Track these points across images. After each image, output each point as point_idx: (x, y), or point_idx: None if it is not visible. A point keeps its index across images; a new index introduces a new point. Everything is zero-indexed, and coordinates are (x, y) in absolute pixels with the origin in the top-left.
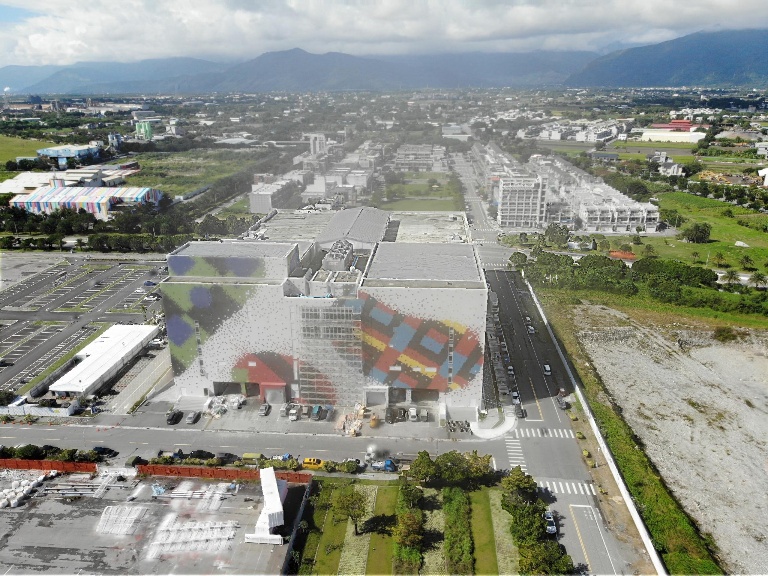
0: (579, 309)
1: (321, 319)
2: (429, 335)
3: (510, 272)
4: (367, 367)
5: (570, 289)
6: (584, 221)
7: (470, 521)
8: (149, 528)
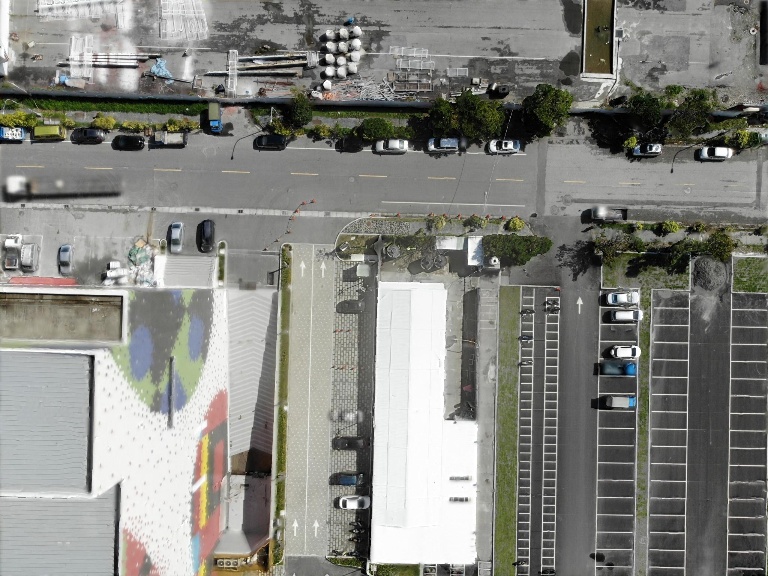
0: None
1: None
2: None
3: None
4: None
5: None
6: None
7: None
8: (144, 6)
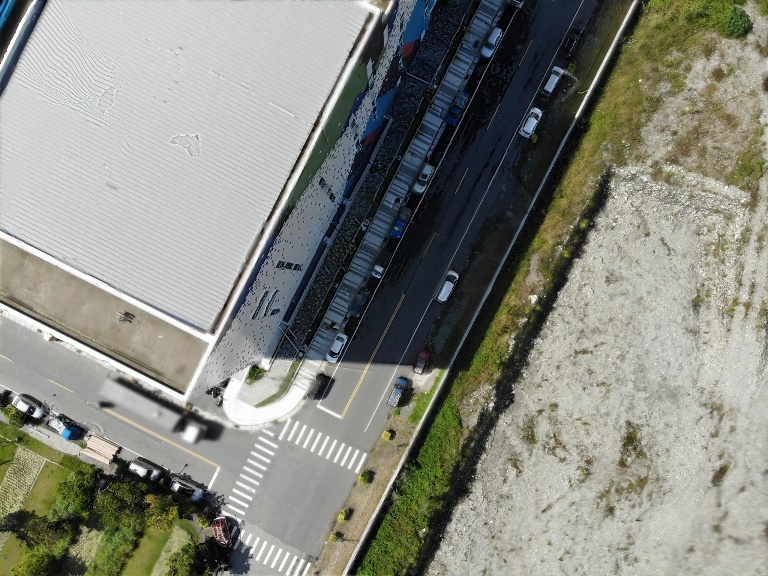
0: (712, 63)
1: None
2: None
3: None
4: None
5: None
6: None
7: (127, 561)
8: None
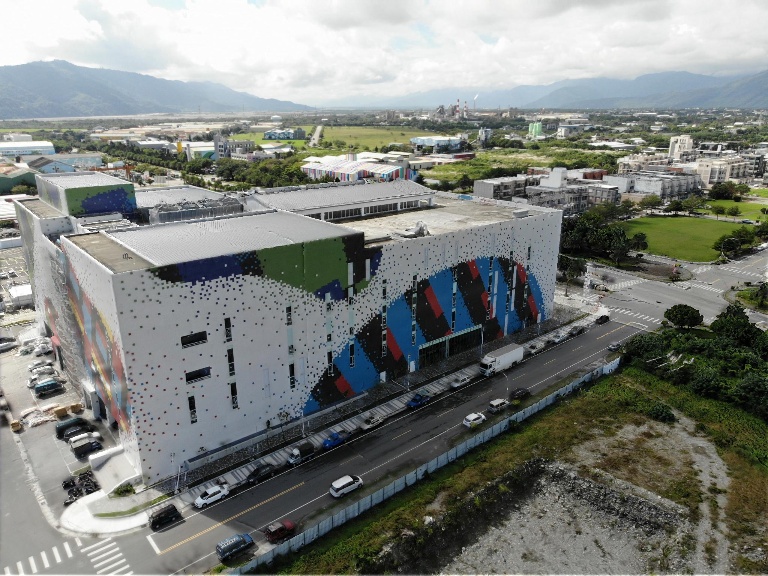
0: (642, 428)
1: None
2: None
3: (646, 334)
4: (83, 353)
5: (694, 391)
6: None
7: None
8: None
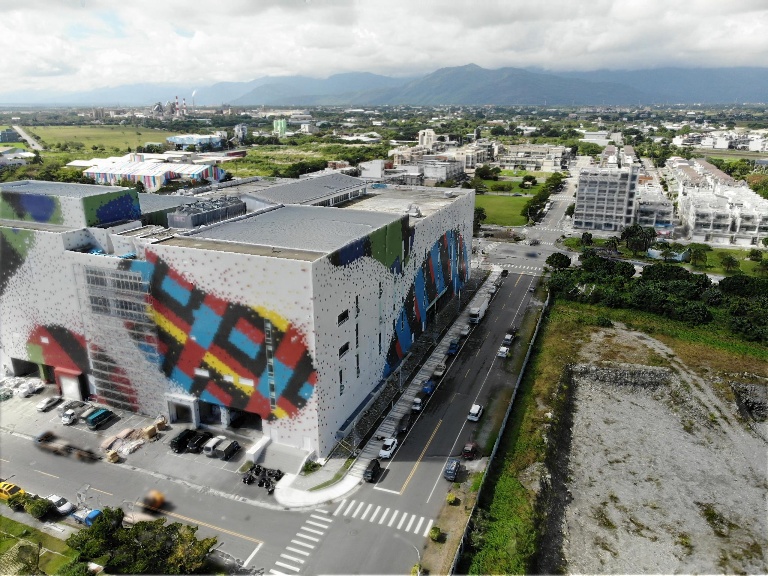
0: (601, 333)
1: (108, 287)
2: (238, 327)
3: (540, 278)
4: (168, 365)
5: (607, 306)
6: (691, 228)
7: None
8: None
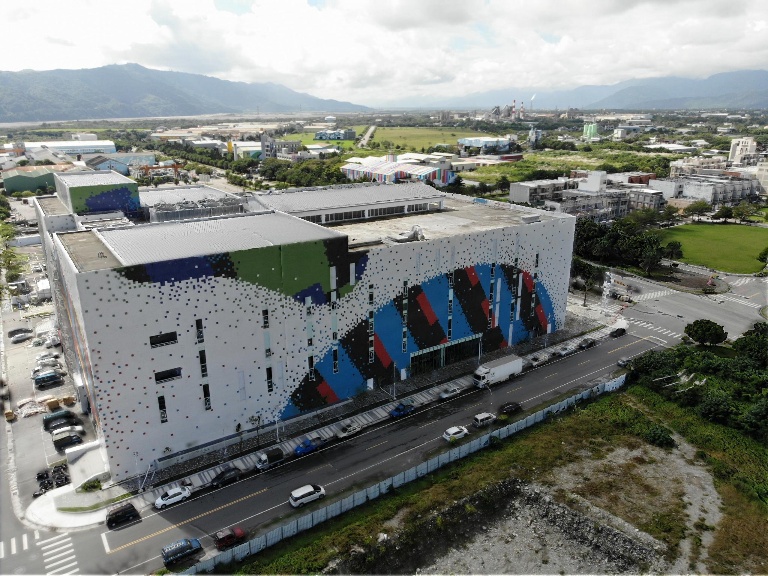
0: (634, 452)
1: None
2: None
3: (663, 349)
4: None
5: (702, 415)
6: None
7: None
8: None
